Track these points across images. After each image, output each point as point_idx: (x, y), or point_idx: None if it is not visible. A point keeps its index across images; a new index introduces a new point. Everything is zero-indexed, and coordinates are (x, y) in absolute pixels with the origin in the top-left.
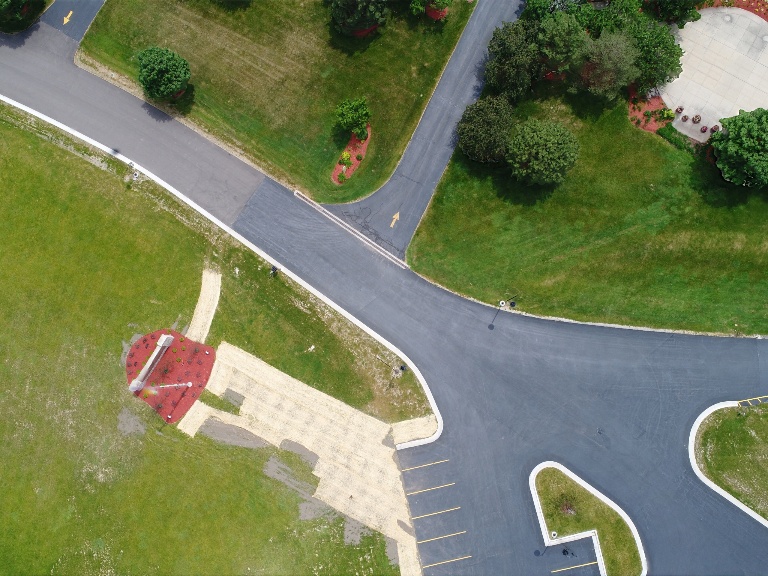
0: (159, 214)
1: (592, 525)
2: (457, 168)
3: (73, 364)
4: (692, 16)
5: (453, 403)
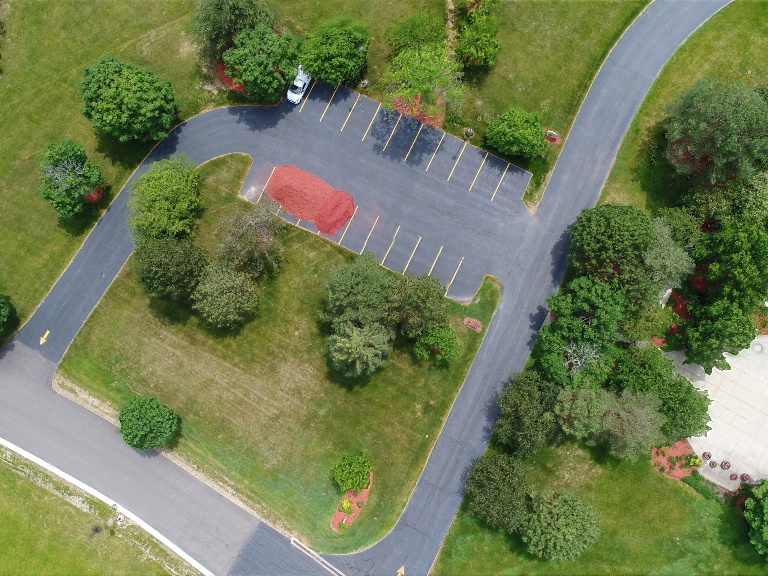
0: (145, 565)
1: None
2: (466, 518)
3: None
4: (721, 367)
5: None
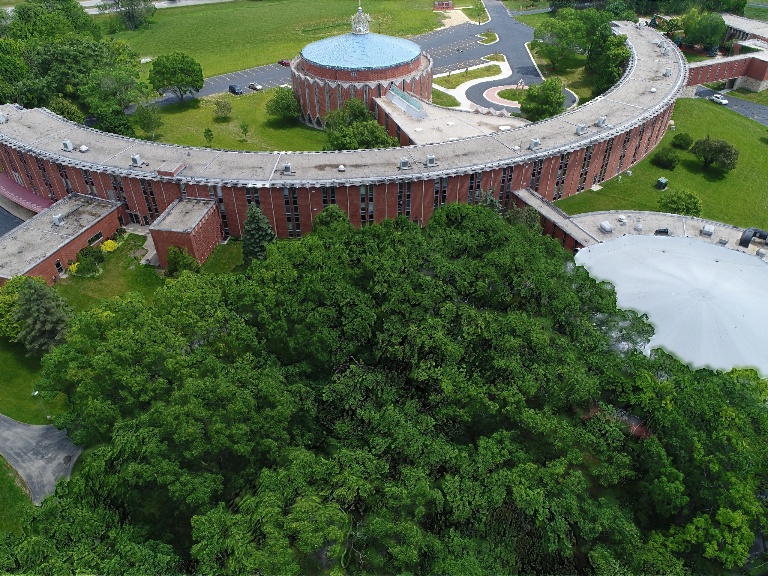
0: None
1: None
2: None
3: (429, 4)
4: None
5: (489, 24)
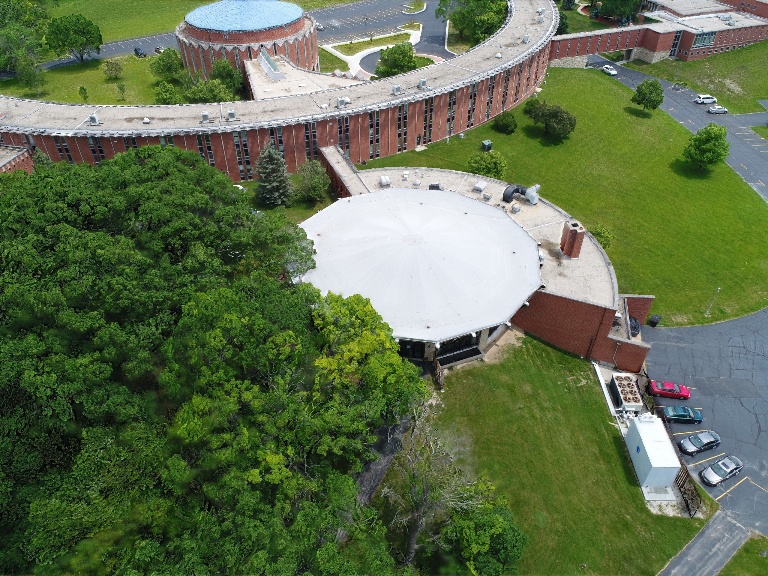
0: None
1: (416, 7)
2: None
3: None
4: None
5: None
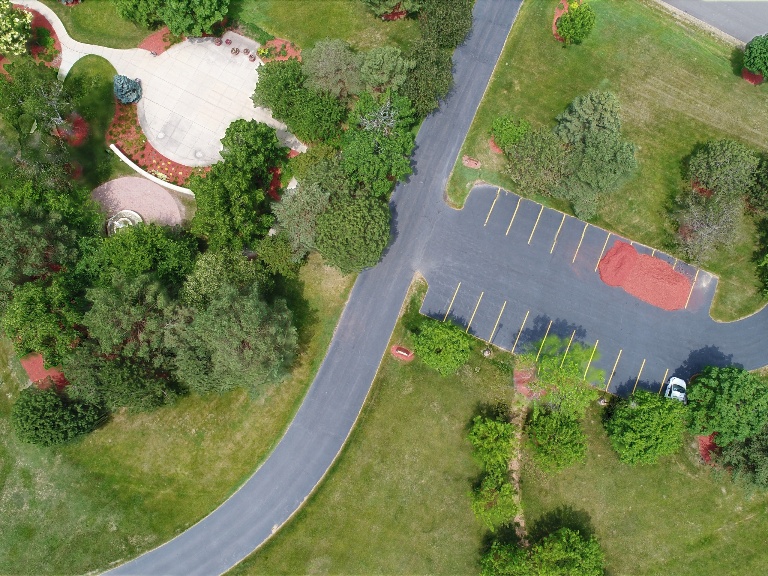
0: None
1: None
2: None
3: None
4: None
5: None
